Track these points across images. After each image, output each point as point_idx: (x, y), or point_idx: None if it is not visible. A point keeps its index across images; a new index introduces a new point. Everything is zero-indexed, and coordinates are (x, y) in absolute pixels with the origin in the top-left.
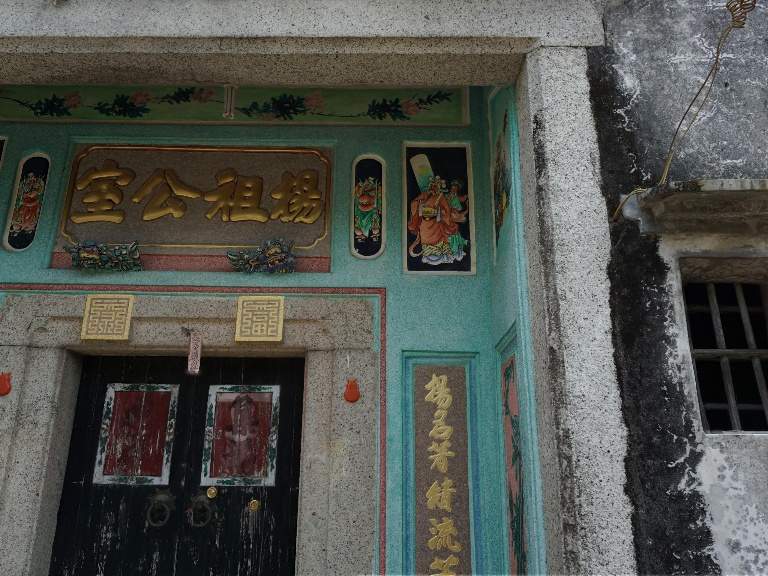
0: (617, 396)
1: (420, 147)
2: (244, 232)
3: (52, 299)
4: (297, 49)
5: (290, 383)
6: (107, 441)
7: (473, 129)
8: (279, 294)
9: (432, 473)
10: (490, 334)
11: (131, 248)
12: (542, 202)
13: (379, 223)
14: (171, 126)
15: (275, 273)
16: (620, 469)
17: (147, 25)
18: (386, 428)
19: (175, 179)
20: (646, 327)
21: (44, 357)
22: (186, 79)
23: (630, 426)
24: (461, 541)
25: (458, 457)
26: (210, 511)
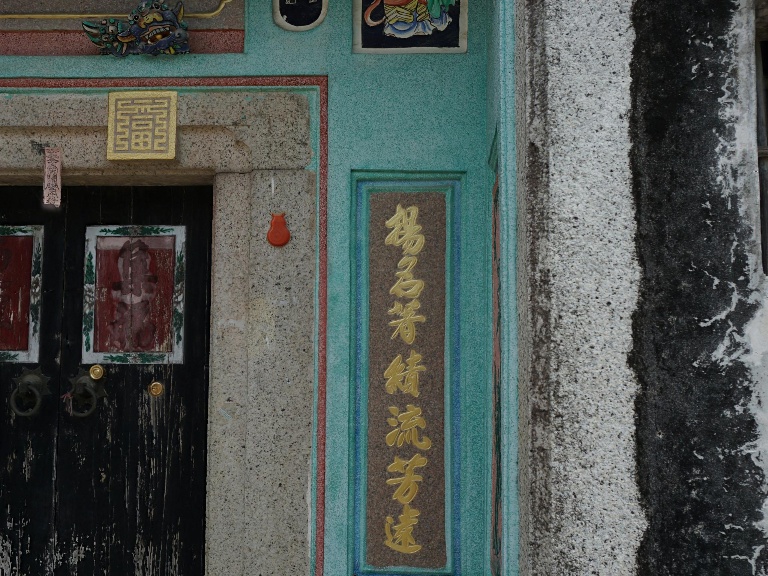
0: (630, 218)
1: None
2: None
3: None
4: None
5: (200, 222)
6: None
7: None
8: (168, 88)
9: (393, 345)
10: (484, 144)
11: None
12: None
13: None
14: None
15: (160, 55)
16: (624, 330)
17: None
18: (327, 282)
19: None
20: (687, 107)
21: None
22: None
23: (646, 265)
24: (431, 436)
25: (431, 323)
26: (94, 396)
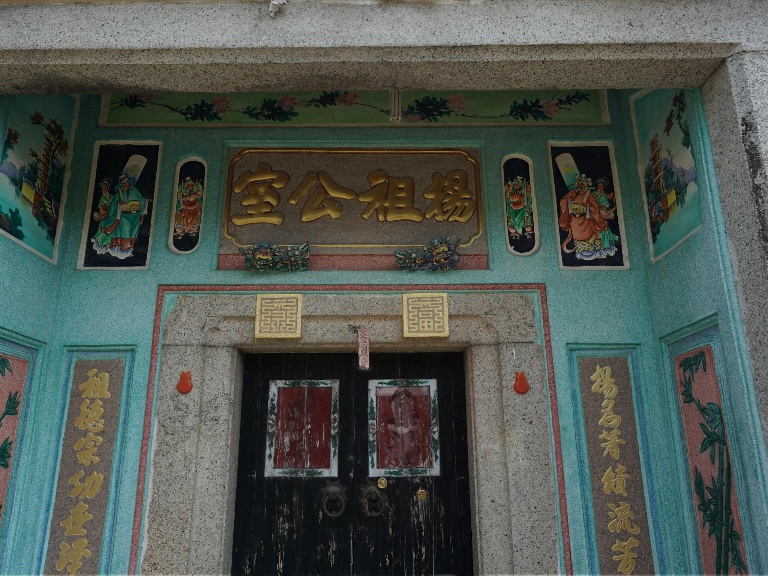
0: None
1: (564, 146)
2: (401, 231)
3: (223, 299)
4: (507, 56)
5: (446, 377)
6: (274, 436)
7: (614, 128)
8: (442, 291)
9: (605, 460)
10: (649, 326)
11: (302, 249)
12: (761, 200)
13: (531, 221)
14: (321, 129)
15: (437, 271)
16: None
17: (363, 35)
18: (559, 418)
19: (329, 181)
20: None
21: (218, 356)
22: (385, 86)
23: None
24: (639, 524)
25: (629, 444)
26: (384, 501)
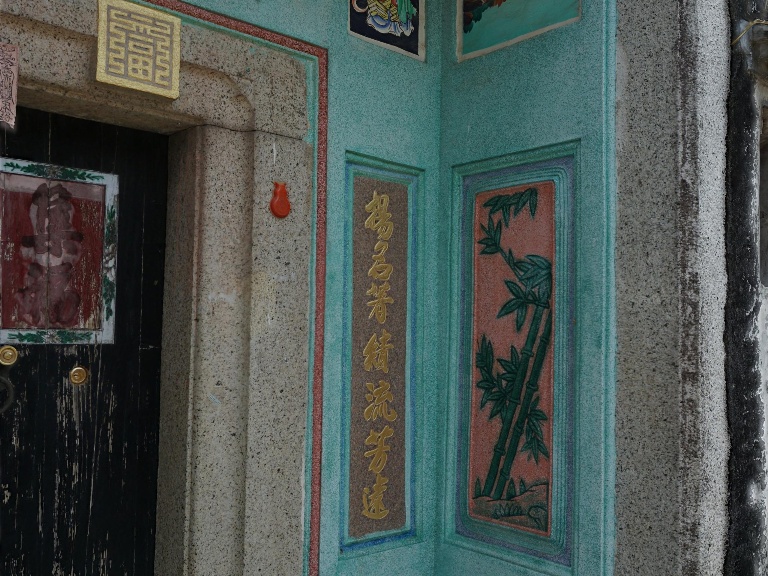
0: (724, 242)
1: None
2: None
3: None
4: None
5: (135, 174)
6: None
7: None
8: (174, 12)
9: (370, 324)
10: (437, 148)
11: None
12: (686, 1)
13: None
14: None
15: None
16: (722, 316)
17: None
18: (326, 260)
19: None
20: (744, 173)
21: None
22: None
23: (729, 274)
24: (397, 408)
25: (397, 304)
26: (11, 388)
